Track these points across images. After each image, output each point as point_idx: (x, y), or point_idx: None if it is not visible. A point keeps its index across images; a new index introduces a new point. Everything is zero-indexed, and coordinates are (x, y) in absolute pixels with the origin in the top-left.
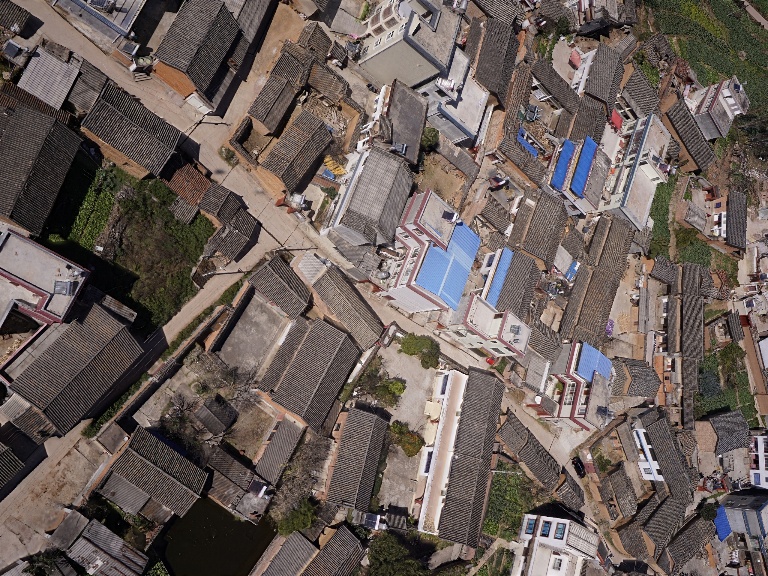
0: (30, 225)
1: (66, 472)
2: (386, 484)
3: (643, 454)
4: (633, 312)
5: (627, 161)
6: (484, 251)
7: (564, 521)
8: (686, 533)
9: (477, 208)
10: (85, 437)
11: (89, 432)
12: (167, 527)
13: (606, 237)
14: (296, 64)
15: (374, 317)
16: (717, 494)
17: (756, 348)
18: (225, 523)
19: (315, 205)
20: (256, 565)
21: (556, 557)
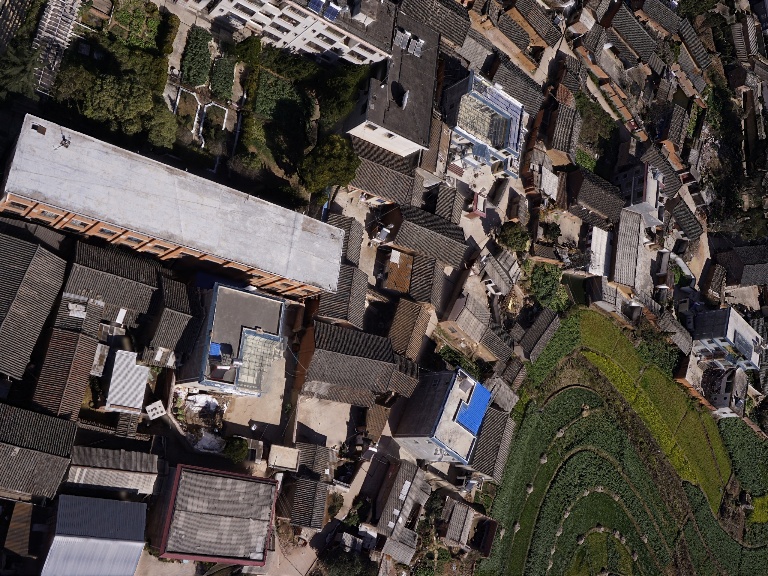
0: (618, 192)
1: None
2: None
3: None
4: None
5: None
6: None
7: None
8: None
9: None
10: None
11: None
12: None
13: None
14: (491, 5)
15: None
16: None
17: None
18: None
19: None
20: None
21: None
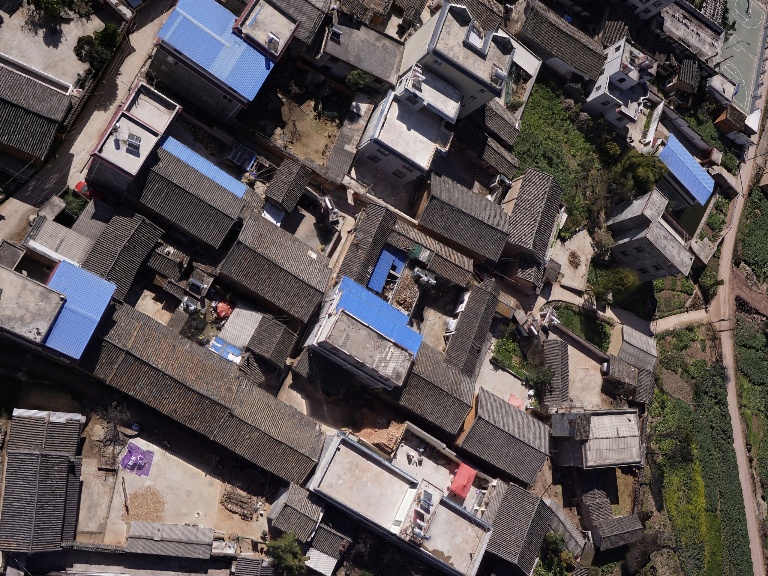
0: None
1: None
2: None
3: None
4: None
5: None
6: None
7: None
8: None
9: None
10: None
11: None
12: None
13: None
14: None
15: None
16: None
17: None
18: None
19: None
20: None
21: None
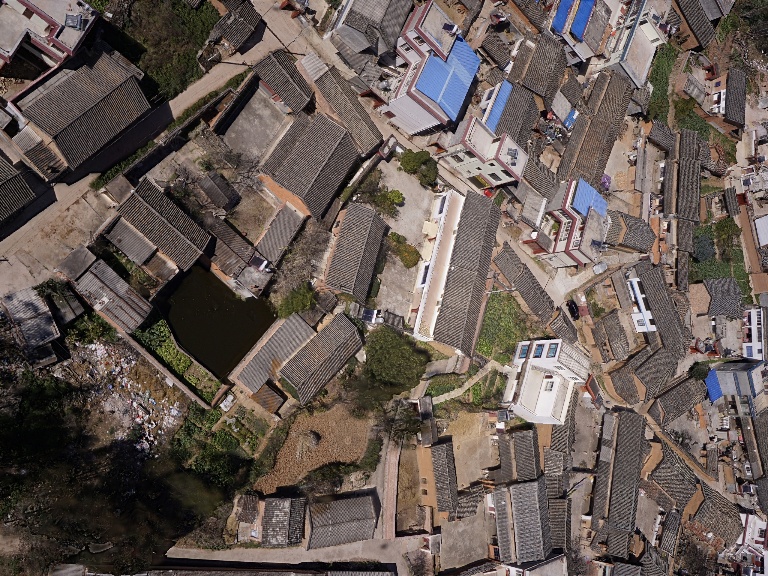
0: None
1: (74, 219)
2: (383, 291)
3: (637, 307)
4: (630, 172)
5: (628, 22)
6: (484, 87)
7: (556, 341)
8: (677, 389)
9: (478, 42)
10: (93, 190)
11: (97, 184)
12: (171, 291)
13: (605, 91)
14: None
15: (374, 125)
16: (709, 361)
17: (752, 226)
18: (227, 306)
19: (319, 15)
20: (256, 344)
21: (548, 380)
